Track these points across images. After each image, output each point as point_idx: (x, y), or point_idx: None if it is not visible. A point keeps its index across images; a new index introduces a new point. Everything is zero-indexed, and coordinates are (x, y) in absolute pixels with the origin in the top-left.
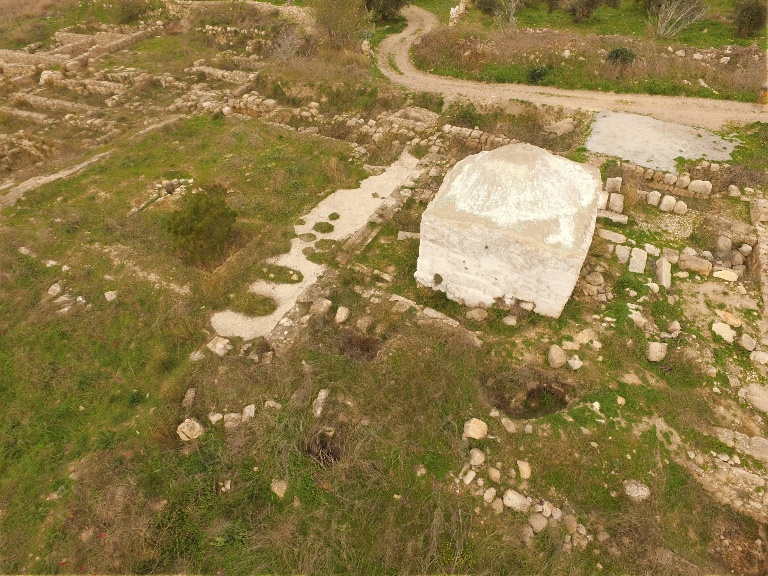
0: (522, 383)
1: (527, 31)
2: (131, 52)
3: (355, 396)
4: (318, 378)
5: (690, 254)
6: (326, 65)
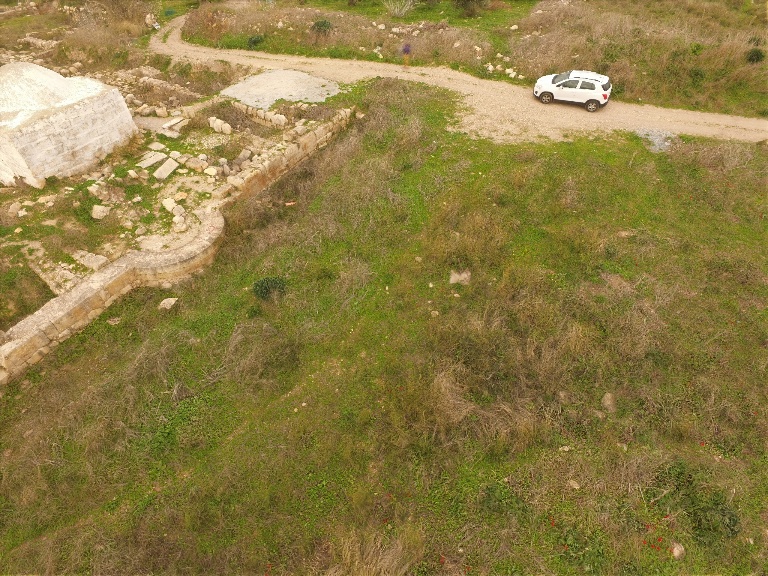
0: None
1: None
2: None
3: None
4: None
5: (200, 158)
6: (100, 33)
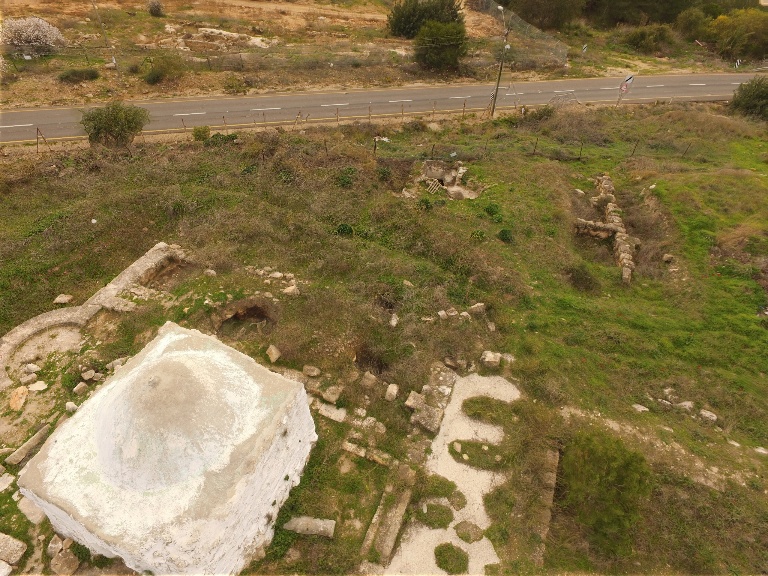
0: None
1: None
2: None
3: None
4: None
5: None
6: None
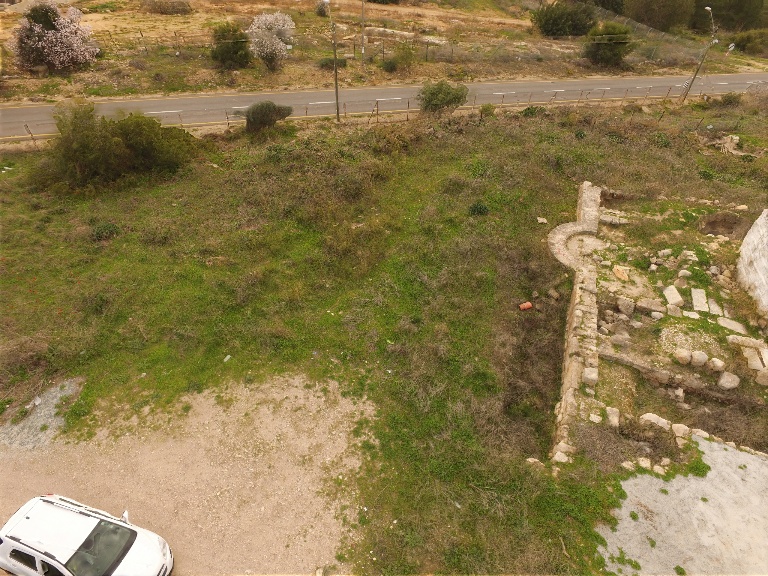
0: None
1: None
2: None
3: None
4: None
5: (658, 312)
6: None
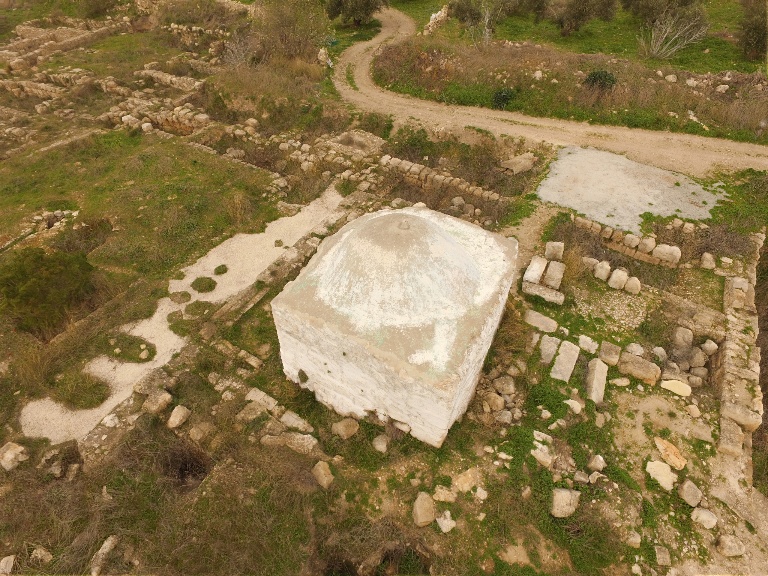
0: (375, 543)
1: (505, 44)
2: (88, 50)
3: (145, 554)
4: (111, 518)
5: (635, 353)
6: (272, 76)
